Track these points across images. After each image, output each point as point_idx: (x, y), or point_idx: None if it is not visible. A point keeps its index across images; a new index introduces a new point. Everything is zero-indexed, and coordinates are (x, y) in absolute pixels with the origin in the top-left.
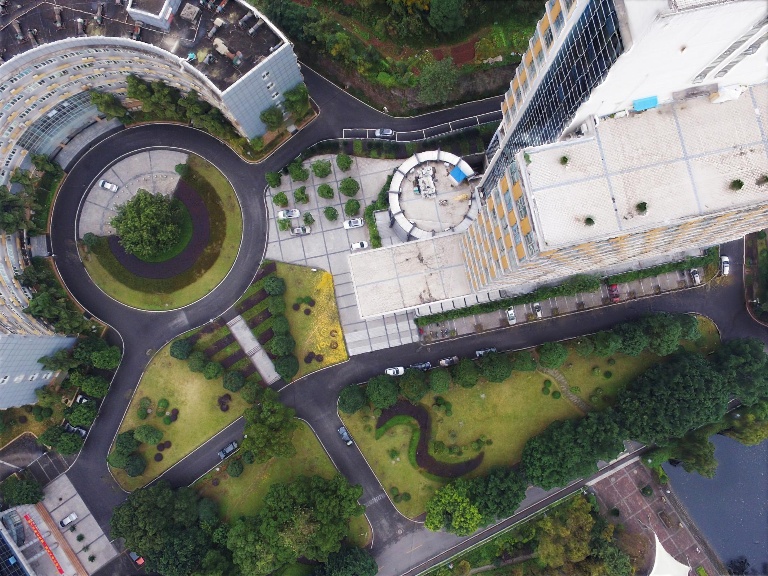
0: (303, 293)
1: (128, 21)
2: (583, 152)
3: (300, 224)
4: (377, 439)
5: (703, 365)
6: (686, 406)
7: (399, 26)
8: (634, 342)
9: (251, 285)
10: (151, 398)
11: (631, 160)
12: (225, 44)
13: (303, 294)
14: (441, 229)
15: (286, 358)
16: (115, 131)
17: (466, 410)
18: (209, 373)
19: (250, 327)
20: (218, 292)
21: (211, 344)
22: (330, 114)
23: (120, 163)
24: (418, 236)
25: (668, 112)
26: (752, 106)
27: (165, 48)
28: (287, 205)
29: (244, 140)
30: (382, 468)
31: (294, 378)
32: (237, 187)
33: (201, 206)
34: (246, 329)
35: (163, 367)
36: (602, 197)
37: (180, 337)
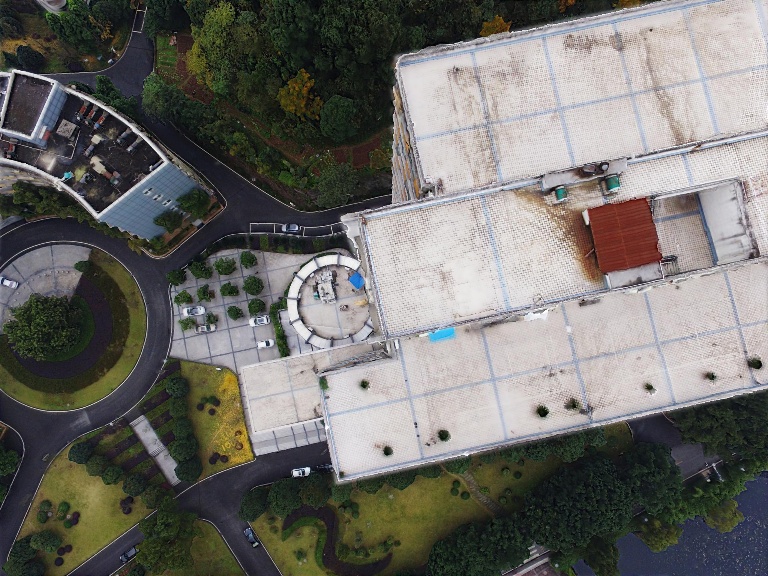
0: (208, 392)
1: (3, 137)
2: (386, 373)
3: (205, 321)
4: (283, 540)
5: (608, 473)
6: (588, 518)
7: (295, 130)
8: (537, 451)
9: (154, 384)
10: (52, 501)
11: (436, 381)
12: (103, 162)
13: (208, 393)
14: (341, 335)
15: (186, 463)
16: (16, 225)
17: (374, 511)
18: (107, 480)
19: (153, 428)
20: (121, 391)
21: (113, 446)
22: (237, 207)
23: (21, 258)
24: (316, 344)
25: (476, 330)
26: (564, 323)
27: (41, 166)
28: (192, 301)
29: (142, 241)
30: (289, 569)
31: (199, 478)
32: (141, 282)
33: (103, 303)
34: (150, 429)
35: (62, 471)
36: (404, 422)
37: (82, 438)
